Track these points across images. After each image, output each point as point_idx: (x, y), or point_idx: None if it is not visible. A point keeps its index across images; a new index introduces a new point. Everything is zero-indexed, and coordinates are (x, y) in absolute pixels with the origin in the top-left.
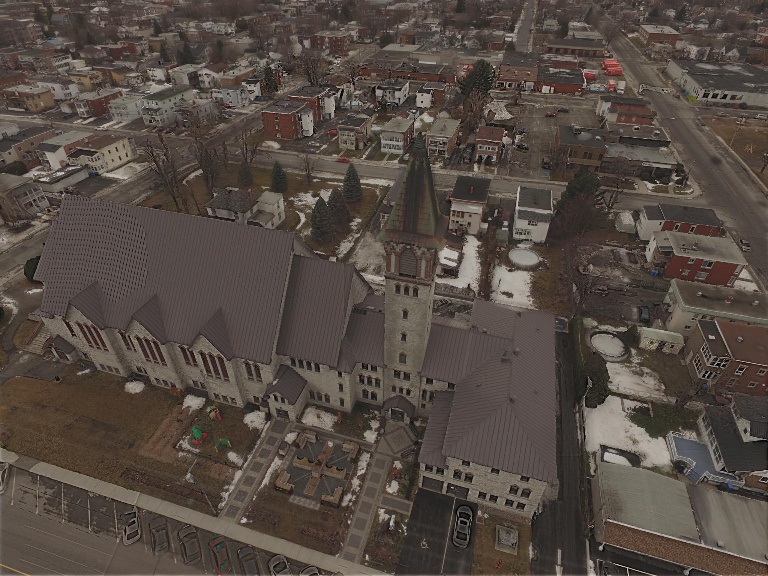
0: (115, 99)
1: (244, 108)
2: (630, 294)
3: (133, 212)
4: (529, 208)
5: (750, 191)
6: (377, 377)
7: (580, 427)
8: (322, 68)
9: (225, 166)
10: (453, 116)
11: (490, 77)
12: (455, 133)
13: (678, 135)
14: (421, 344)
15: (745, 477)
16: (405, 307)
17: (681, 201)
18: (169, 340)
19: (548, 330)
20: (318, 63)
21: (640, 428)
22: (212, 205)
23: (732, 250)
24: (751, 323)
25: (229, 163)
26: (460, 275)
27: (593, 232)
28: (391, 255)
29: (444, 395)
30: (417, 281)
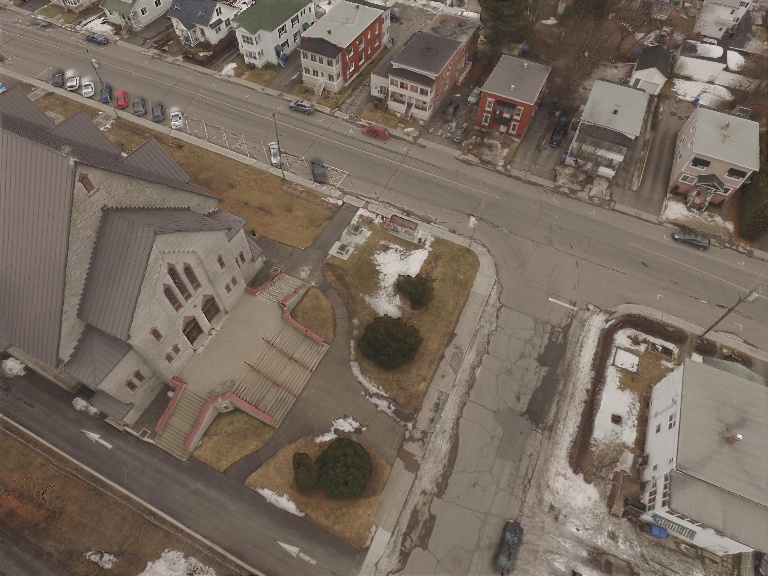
0: None
1: None
2: None
3: None
4: None
5: None
6: None
7: None
8: None
9: None
10: None
11: None
12: None
13: None
14: None
15: None
16: None
17: None
18: None
19: None
20: None
21: None
22: None
23: None
24: None
25: None
26: None
27: None
28: None
29: None
30: None
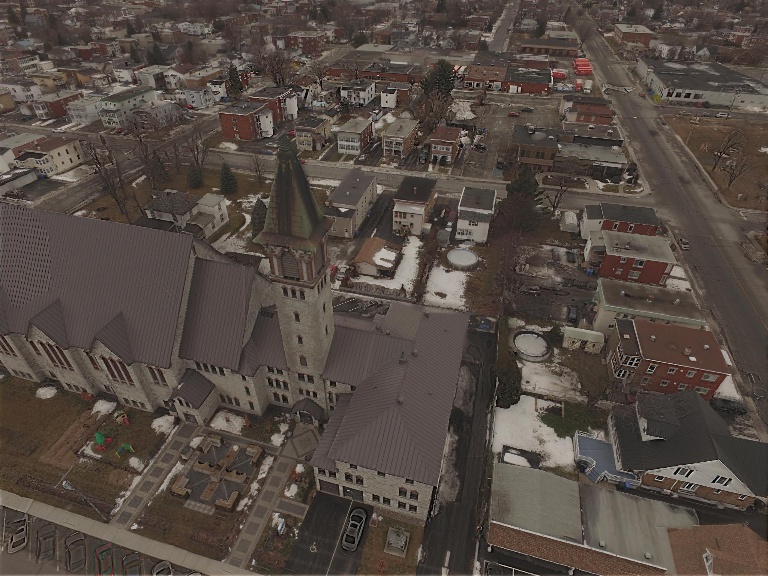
0: (74, 101)
1: (208, 109)
2: (562, 293)
3: (37, 216)
4: (470, 208)
5: (699, 190)
6: (284, 380)
7: (489, 428)
8: (288, 69)
9: (177, 168)
10: (416, 116)
11: (451, 77)
12: (412, 133)
13: (637, 134)
14: (317, 347)
15: (642, 476)
16: (295, 310)
17: (629, 200)
18: (71, 345)
19: (458, 331)
20: (283, 64)
21: (549, 428)
22: (150, 207)
23: (664, 249)
24: (670, 322)
25: (183, 165)
26: (396, 276)
27: (536, 232)
28: (273, 258)
29: (348, 397)
30: (301, 284)
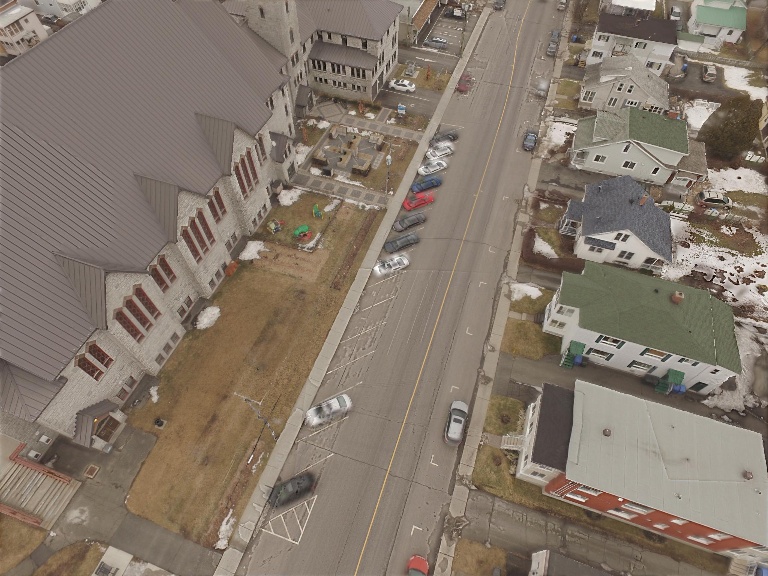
0: None
1: None
2: None
3: None
4: None
5: None
6: None
7: None
8: None
9: None
10: None
11: None
12: None
13: None
14: (295, 5)
15: None
16: None
17: None
18: (205, 193)
19: None
20: None
21: None
22: None
23: None
24: None
25: None
26: None
27: None
28: None
29: (315, 51)
30: None
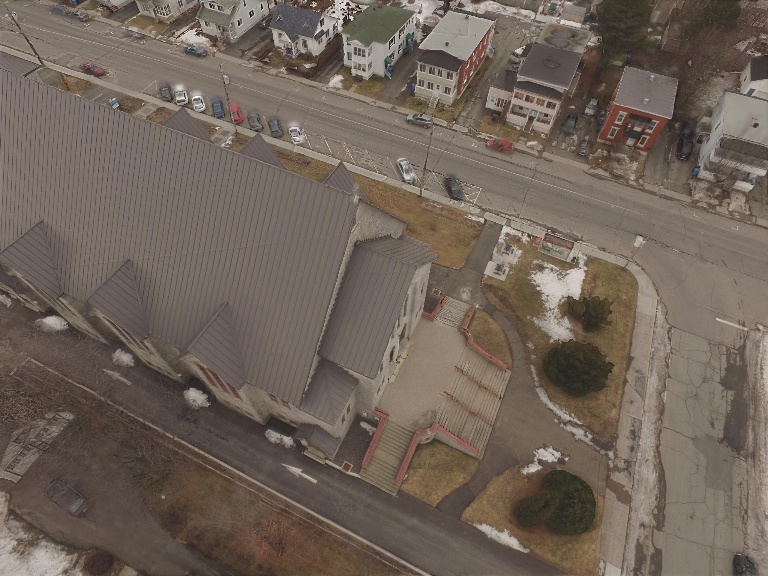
0: None
1: None
2: None
3: None
4: None
5: None
6: None
7: None
8: None
9: None
10: None
11: None
12: None
13: None
14: None
15: None
16: None
17: None
18: None
19: None
20: None
21: None
22: None
23: None
24: None
25: None
26: None
27: None
28: None
29: None
30: None
